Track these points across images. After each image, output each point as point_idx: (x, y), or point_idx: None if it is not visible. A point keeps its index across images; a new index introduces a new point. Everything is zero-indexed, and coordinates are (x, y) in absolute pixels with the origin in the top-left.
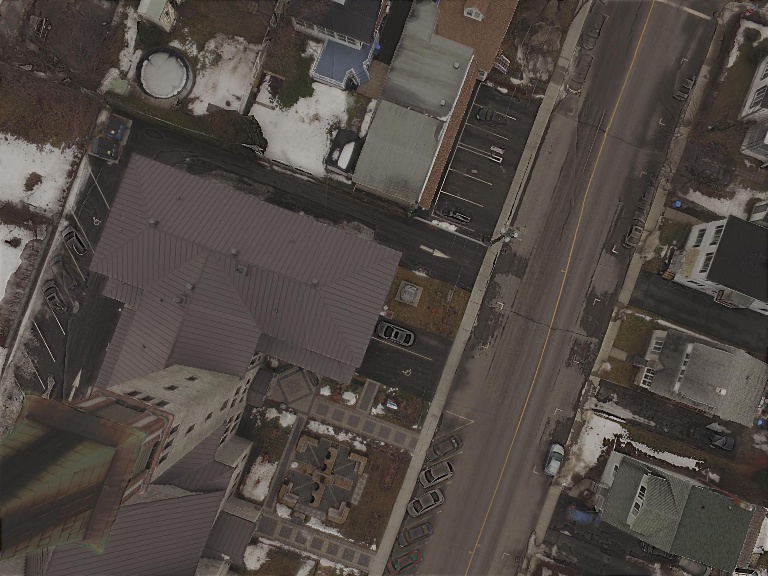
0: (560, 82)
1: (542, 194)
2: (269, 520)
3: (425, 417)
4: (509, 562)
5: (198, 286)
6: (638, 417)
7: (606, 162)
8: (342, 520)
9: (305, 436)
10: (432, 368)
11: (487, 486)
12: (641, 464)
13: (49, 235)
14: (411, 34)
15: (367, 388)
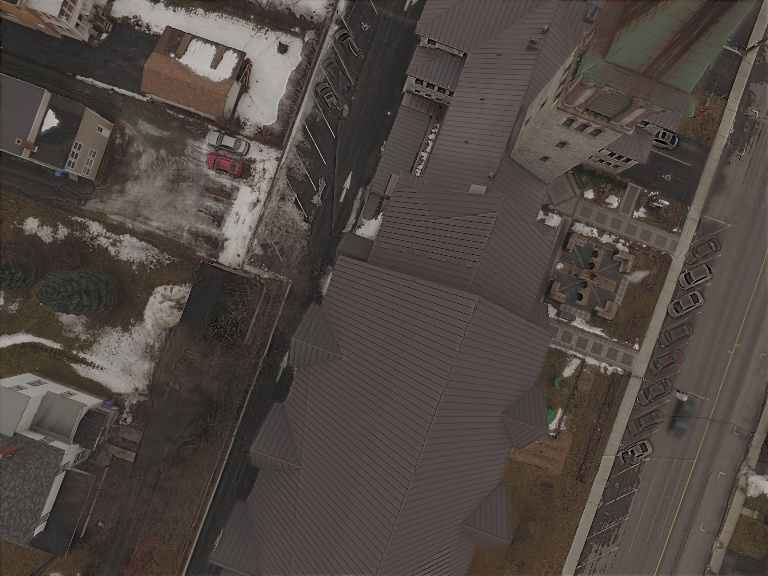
0: None
1: None
2: None
3: (684, 221)
4: (766, 362)
5: (550, 30)
6: None
7: None
8: (612, 316)
9: (576, 234)
10: (691, 173)
11: (745, 288)
12: None
13: (322, 37)
14: None
15: (629, 192)
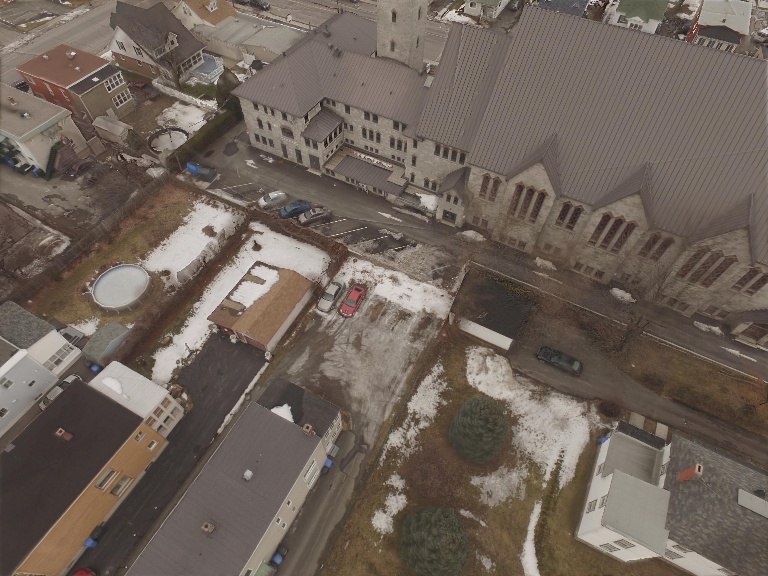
0: (261, 11)
1: (319, 22)
2: None
3: None
4: None
5: None
6: (447, 7)
7: (310, 3)
8: None
9: None
10: None
11: None
12: None
13: None
14: (209, 34)
15: None
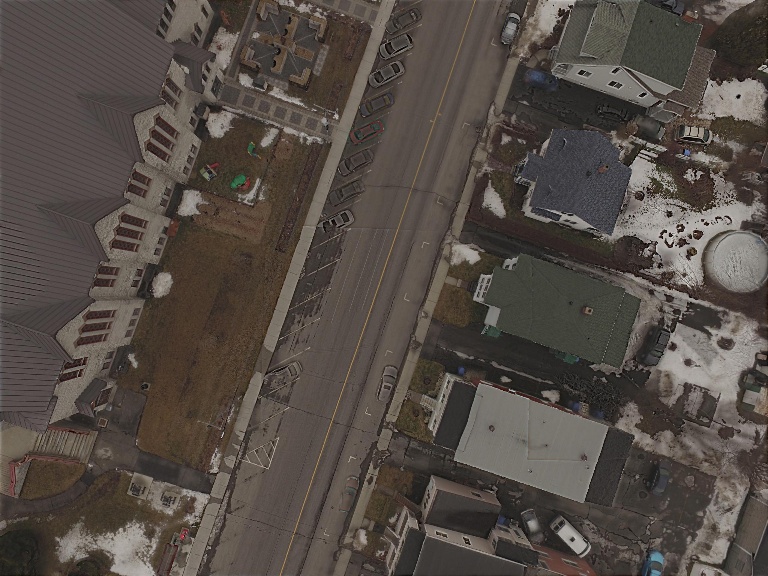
0: None
1: None
2: (232, 89)
3: None
4: (469, 132)
5: None
6: None
7: None
8: (304, 81)
9: None
10: None
11: (446, 57)
12: (593, 1)
13: None
14: None
15: None
